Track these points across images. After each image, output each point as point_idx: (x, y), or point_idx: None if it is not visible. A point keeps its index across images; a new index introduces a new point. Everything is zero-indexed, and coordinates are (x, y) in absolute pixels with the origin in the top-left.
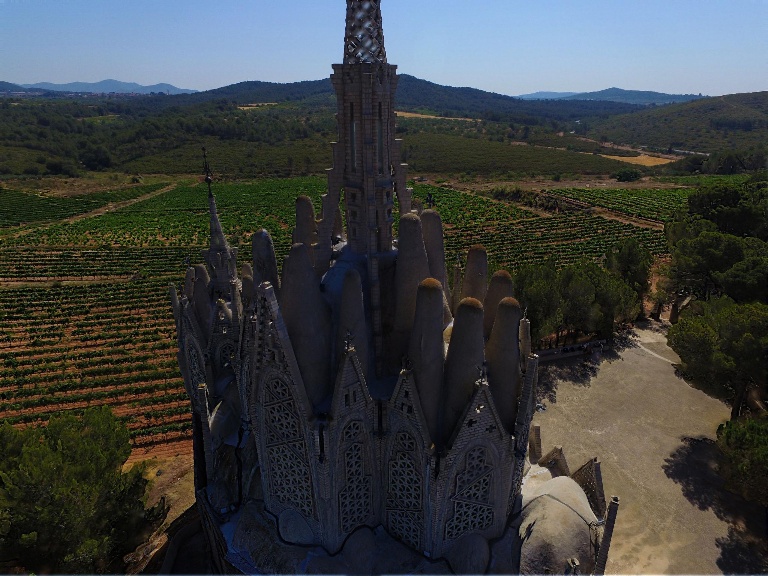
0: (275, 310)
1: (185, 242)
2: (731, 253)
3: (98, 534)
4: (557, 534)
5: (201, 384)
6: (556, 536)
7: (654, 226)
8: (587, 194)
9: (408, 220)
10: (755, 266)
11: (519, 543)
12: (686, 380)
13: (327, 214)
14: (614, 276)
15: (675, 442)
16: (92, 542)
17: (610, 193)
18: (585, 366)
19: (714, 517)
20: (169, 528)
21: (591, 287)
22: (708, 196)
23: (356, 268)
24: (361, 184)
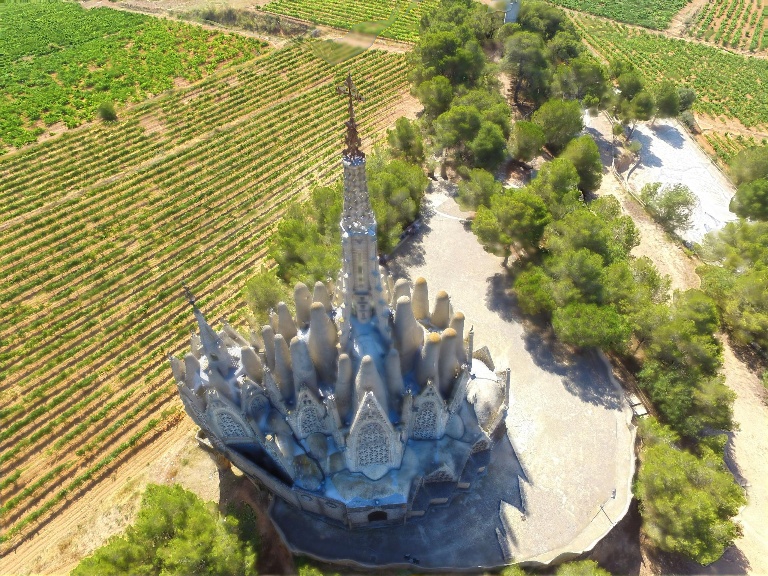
0: (376, 401)
1: None
2: (473, 122)
3: (241, 551)
4: (489, 395)
5: (268, 437)
6: (489, 397)
7: (377, 44)
8: (303, 6)
9: (406, 304)
10: (489, 133)
11: (472, 407)
12: (486, 251)
13: (347, 314)
14: (401, 155)
15: (484, 284)
16: (252, 557)
17: (323, 0)
18: (415, 247)
19: (516, 323)
20: (222, 513)
21: (407, 191)
22: (435, 47)
23: (373, 336)
24: (368, 291)
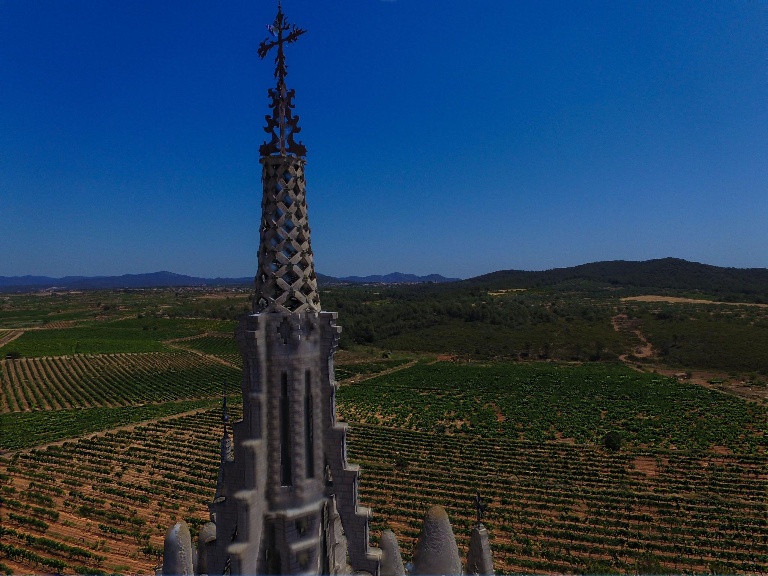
0: None
1: (397, 423)
2: None
3: None
4: None
5: None
6: None
7: None
8: None
9: None
10: None
11: None
12: None
13: (219, 532)
14: None
15: None
16: None
17: None
18: None
19: None
20: None
21: None
22: None
23: None
24: None
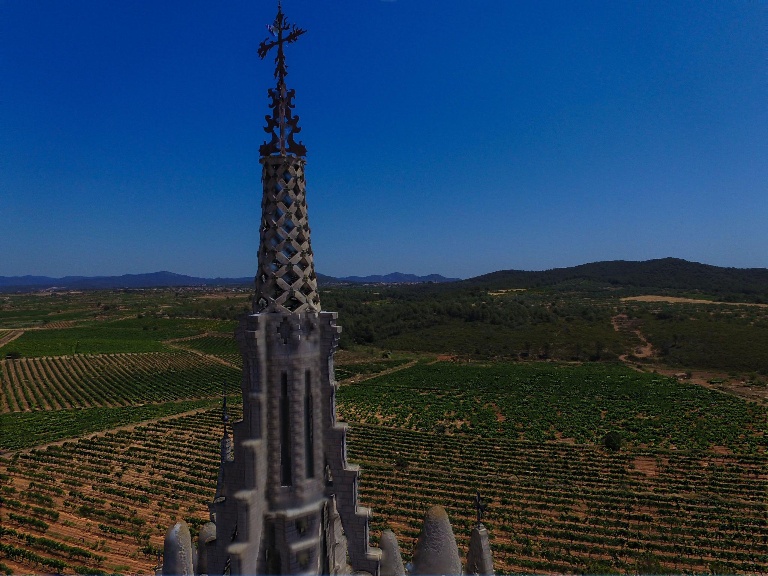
0: None
1: (397, 423)
2: None
3: None
4: None
5: None
6: None
7: None
8: None
9: None
10: None
11: None
12: None
13: (219, 532)
14: None
15: None
16: None
17: None
18: None
19: None
20: None
21: None
22: None
23: None
24: None
